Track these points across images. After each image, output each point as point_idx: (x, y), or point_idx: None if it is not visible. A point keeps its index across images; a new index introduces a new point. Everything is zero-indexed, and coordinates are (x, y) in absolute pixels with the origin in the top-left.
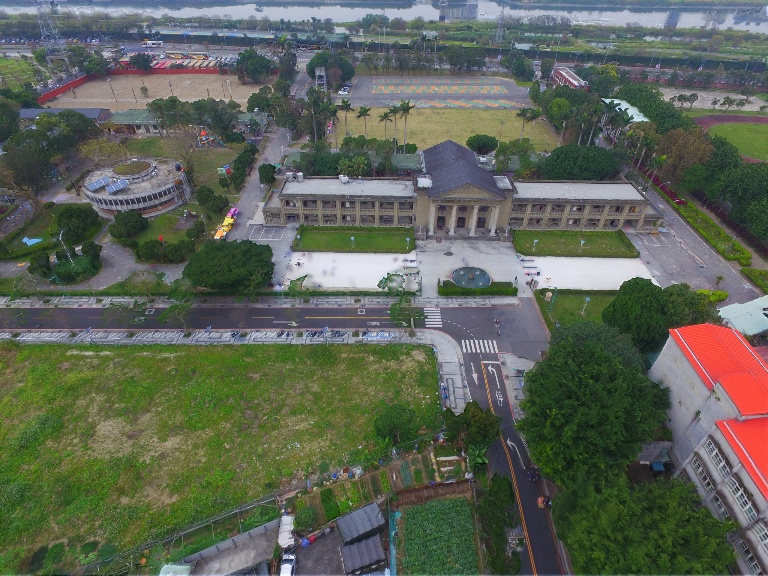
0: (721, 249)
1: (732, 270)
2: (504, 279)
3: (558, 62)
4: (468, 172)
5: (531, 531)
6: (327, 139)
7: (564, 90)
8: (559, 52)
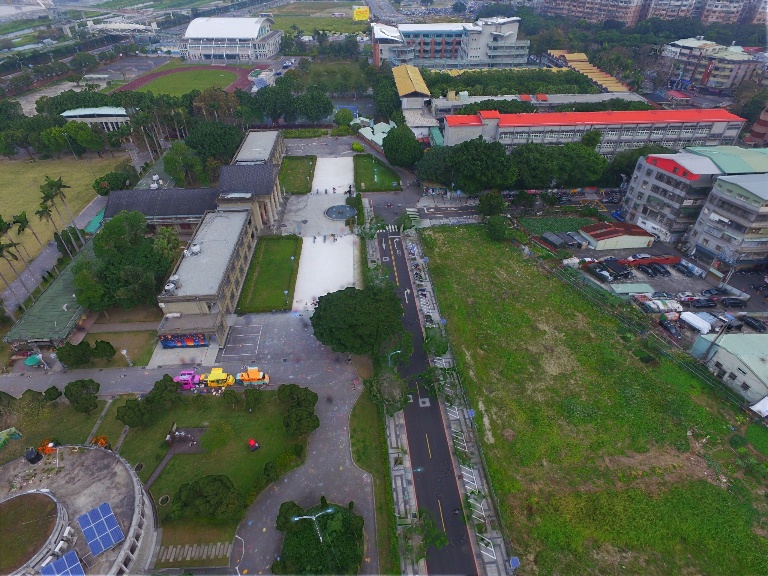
0: (311, 135)
1: (330, 138)
2: (341, 201)
3: None
4: None
5: None
6: None
7: (24, 123)
8: None
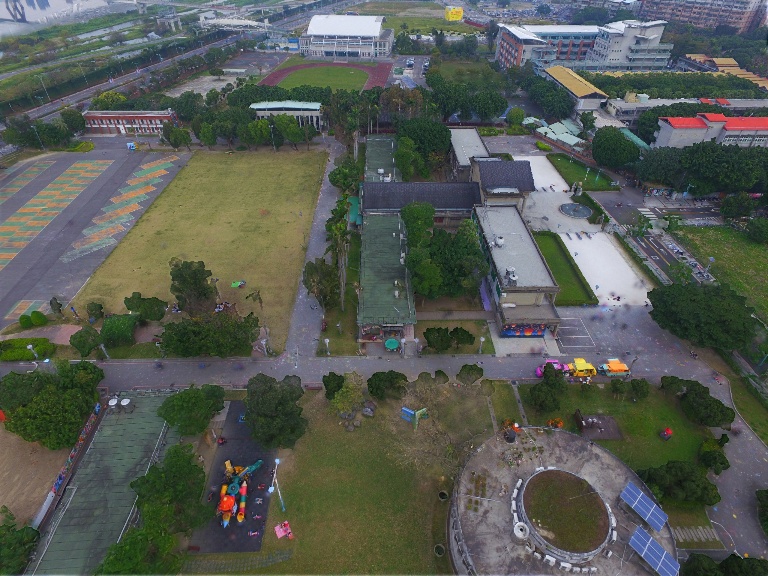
0: (488, 133)
1: None
2: (566, 199)
3: None
4: None
5: None
6: (256, 308)
7: (228, 115)
8: None
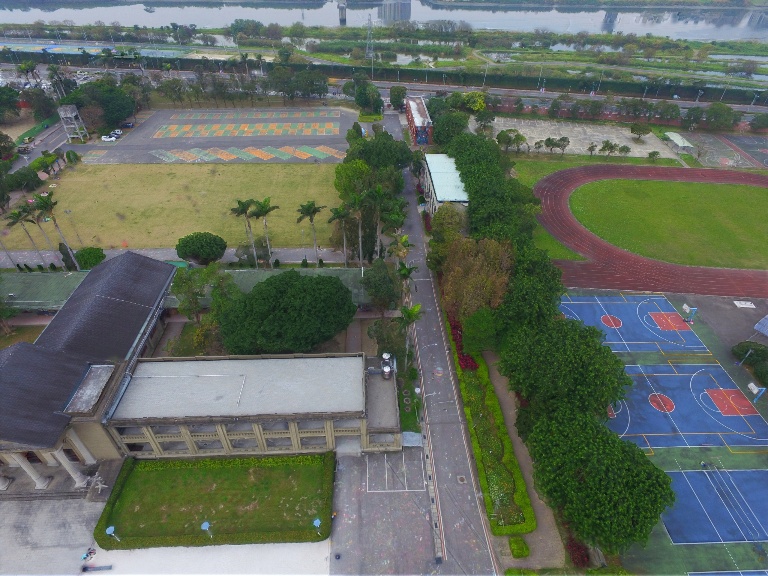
0: (489, 503)
1: (491, 569)
2: None
3: (429, 83)
4: None
5: None
6: None
7: (375, 142)
8: (429, 71)
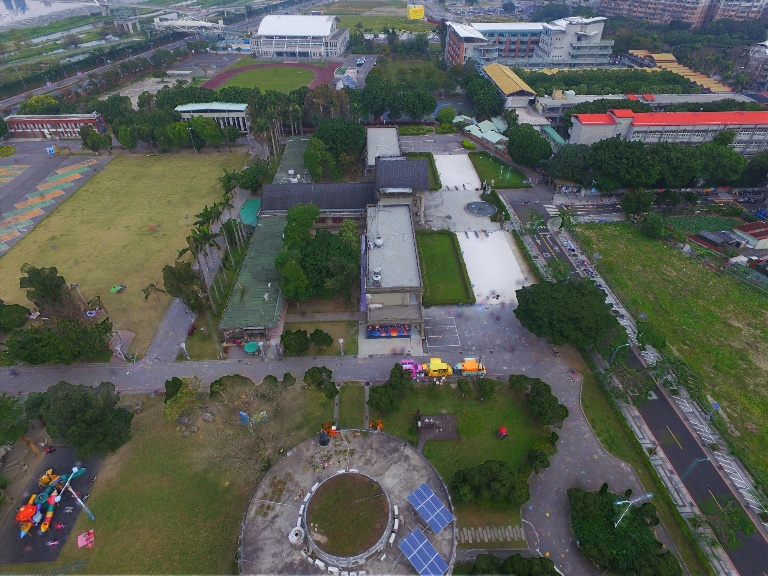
0: (417, 132)
1: (436, 135)
2: (475, 198)
3: None
4: (404, 160)
5: (661, 205)
6: (128, 313)
7: (147, 117)
8: None
